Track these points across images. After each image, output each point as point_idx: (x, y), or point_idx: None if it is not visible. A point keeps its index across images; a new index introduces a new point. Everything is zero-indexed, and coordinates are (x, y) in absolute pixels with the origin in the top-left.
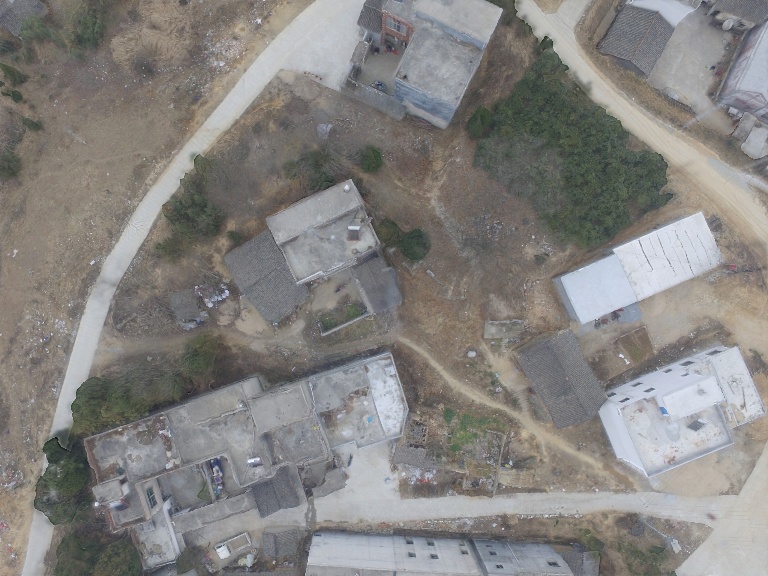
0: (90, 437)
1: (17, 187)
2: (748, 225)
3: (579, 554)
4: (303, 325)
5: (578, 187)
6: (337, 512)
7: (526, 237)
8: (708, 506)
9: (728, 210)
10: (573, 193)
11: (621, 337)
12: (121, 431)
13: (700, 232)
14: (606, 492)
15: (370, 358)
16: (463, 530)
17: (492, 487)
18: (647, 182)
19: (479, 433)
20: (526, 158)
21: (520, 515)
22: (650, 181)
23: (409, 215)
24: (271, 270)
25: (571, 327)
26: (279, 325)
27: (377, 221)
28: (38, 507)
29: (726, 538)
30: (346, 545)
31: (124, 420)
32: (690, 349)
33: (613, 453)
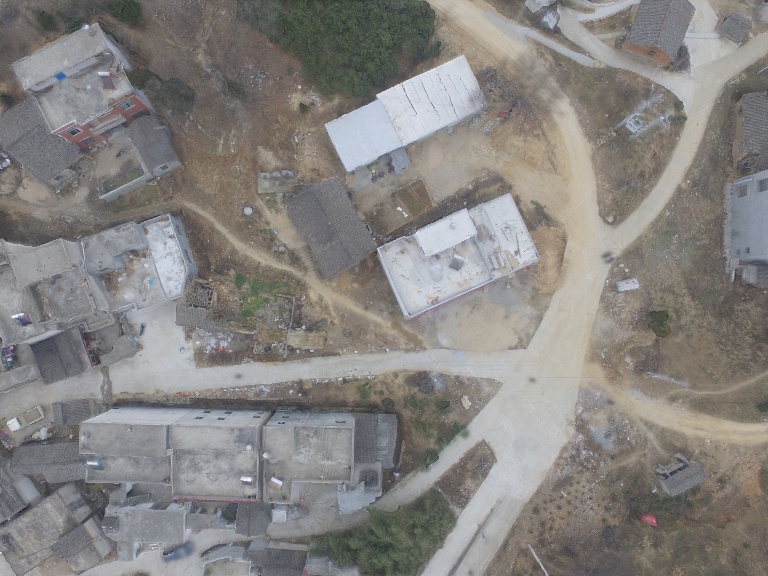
0: None
1: None
2: (527, 77)
3: (374, 416)
4: (87, 193)
5: (341, 34)
6: (133, 384)
7: (293, 87)
8: (497, 361)
9: (506, 62)
10: (335, 40)
11: (398, 190)
12: None
13: (463, 75)
14: (396, 351)
15: (149, 220)
16: (260, 397)
17: (283, 351)
18: (412, 29)
19: (270, 298)
20: (287, 6)
21: (315, 380)
22: (416, 28)
23: (176, 70)
24: (34, 126)
25: (347, 181)
26: (62, 193)
27: (130, 68)
28: None
29: (516, 392)
30: (137, 413)
31: None
32: (475, 204)
33: (400, 311)
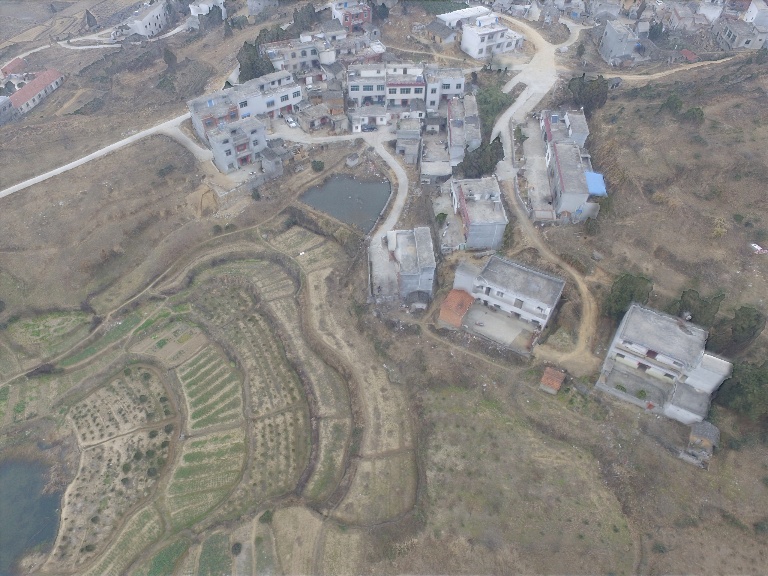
0: (262, 45)
1: (231, 38)
2: None
3: None
4: None
5: None
6: None
7: None
8: None
9: None
10: None
11: None
12: (273, 46)
13: (482, 8)
14: None
15: None
16: None
17: None
18: None
19: None
20: None
21: None
22: None
23: None
24: None
25: None
26: None
27: None
28: (239, 54)
29: None
30: None
31: (276, 38)
32: None
33: (473, 58)
